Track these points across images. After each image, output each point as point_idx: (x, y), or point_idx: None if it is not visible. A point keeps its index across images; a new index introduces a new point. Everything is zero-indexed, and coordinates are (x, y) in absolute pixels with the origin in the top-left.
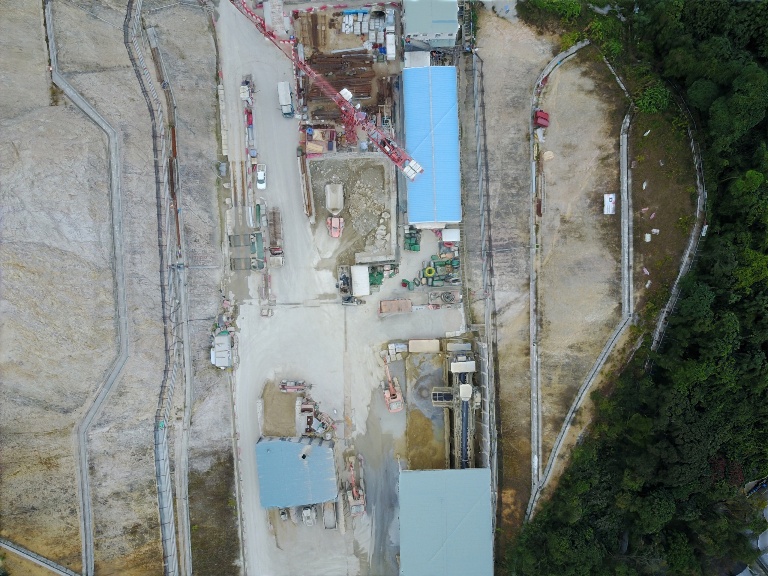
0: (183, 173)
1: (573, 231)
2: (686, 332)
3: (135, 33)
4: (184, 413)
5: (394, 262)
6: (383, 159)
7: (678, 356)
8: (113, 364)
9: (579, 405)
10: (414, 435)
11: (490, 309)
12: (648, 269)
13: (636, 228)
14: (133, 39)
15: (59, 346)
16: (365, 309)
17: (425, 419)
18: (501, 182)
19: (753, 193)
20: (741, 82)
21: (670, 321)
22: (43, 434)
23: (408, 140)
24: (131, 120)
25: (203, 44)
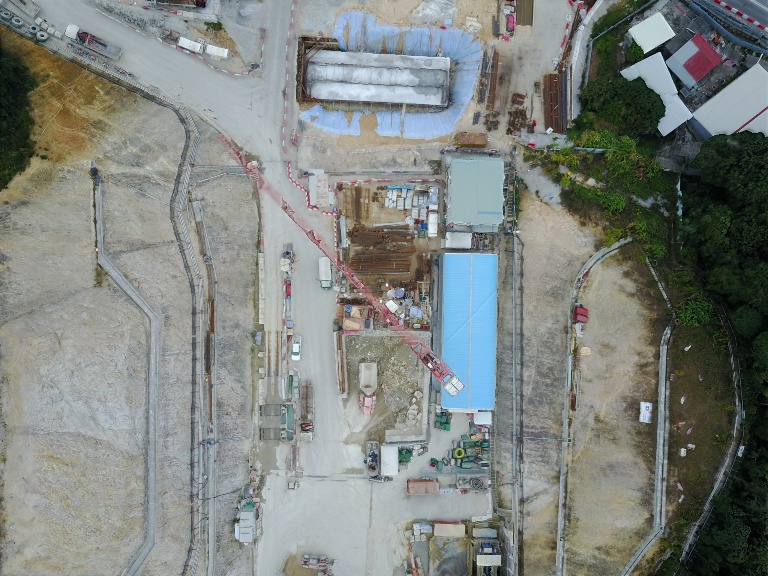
0: (219, 347)
1: (607, 432)
2: (718, 557)
3: (181, 207)
4: None
5: (424, 442)
6: (419, 337)
7: None
8: (139, 550)
9: None
10: None
11: (518, 496)
12: (682, 484)
13: (672, 441)
14: (179, 214)
15: (87, 538)
16: (392, 486)
17: None
18: (536, 369)
19: None
20: None
21: (701, 537)
22: None
23: (446, 325)
24: (172, 299)
25: (246, 213)
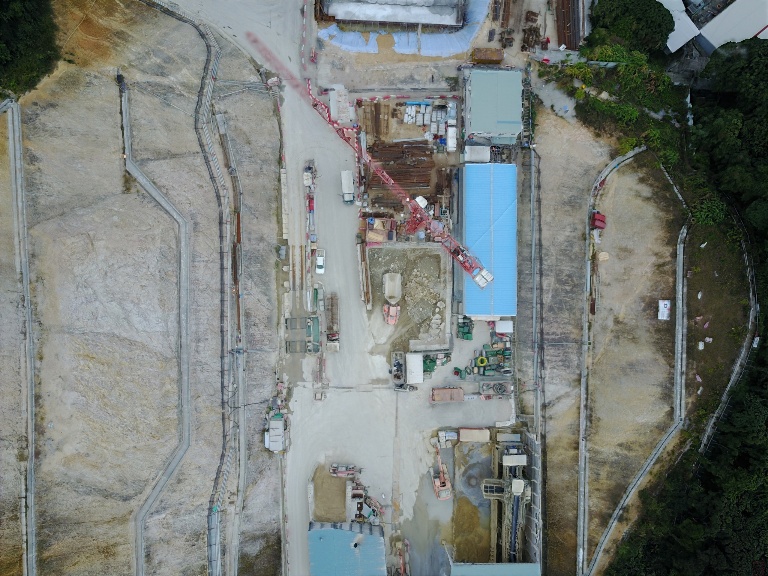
0: (246, 258)
1: (626, 332)
2: (737, 442)
3: (205, 119)
4: (237, 497)
5: (448, 351)
6: (440, 249)
7: (728, 464)
8: (174, 452)
9: (626, 502)
10: (460, 522)
11: (540, 401)
12: (700, 376)
13: (690, 335)
14: (203, 125)
15: (124, 437)
16: (417, 395)
17: (472, 507)
18: (555, 277)
19: None
20: None
21: (719, 427)
22: (102, 523)
23: (468, 234)
24: (200, 208)
25: (268, 129)
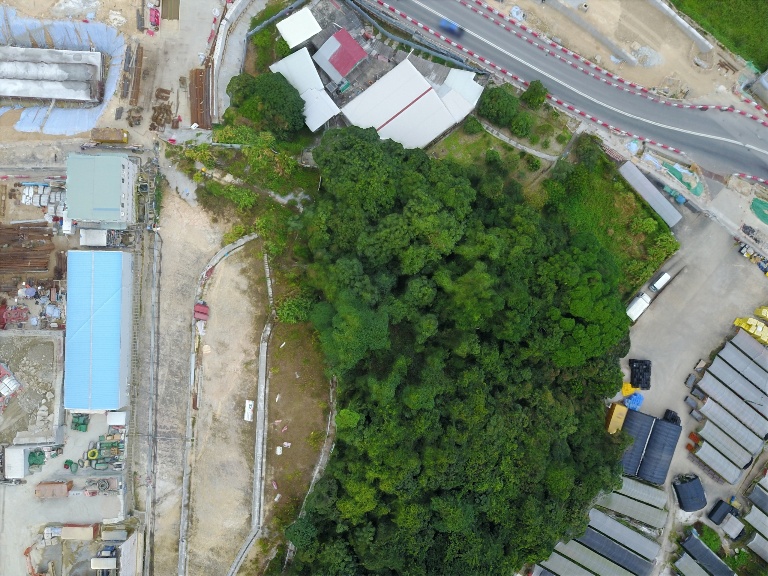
0: None
1: (221, 431)
2: None
3: None
4: None
5: (55, 444)
6: (52, 336)
7: None
8: None
9: None
10: None
11: (151, 497)
12: (278, 483)
13: (269, 440)
14: None
15: None
16: (25, 489)
17: None
18: (168, 368)
19: (354, 428)
20: (338, 320)
21: None
22: None
23: (68, 324)
24: None
25: None
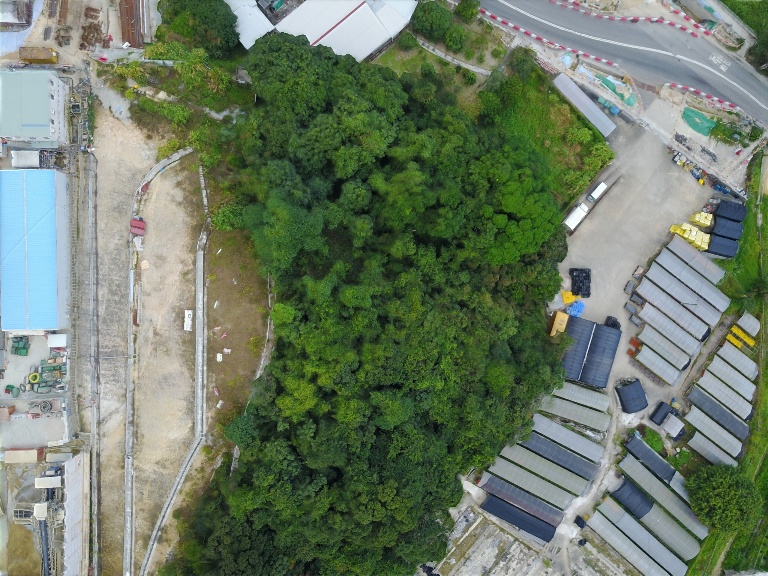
0: None
1: (162, 344)
2: None
3: None
4: None
5: None
6: None
7: (236, 481)
8: None
9: (164, 523)
10: (13, 548)
11: (95, 418)
12: (219, 389)
13: (208, 347)
14: None
15: None
16: None
17: (25, 531)
18: (108, 287)
19: (289, 324)
20: (268, 215)
21: None
22: None
23: (2, 245)
24: None
25: None
